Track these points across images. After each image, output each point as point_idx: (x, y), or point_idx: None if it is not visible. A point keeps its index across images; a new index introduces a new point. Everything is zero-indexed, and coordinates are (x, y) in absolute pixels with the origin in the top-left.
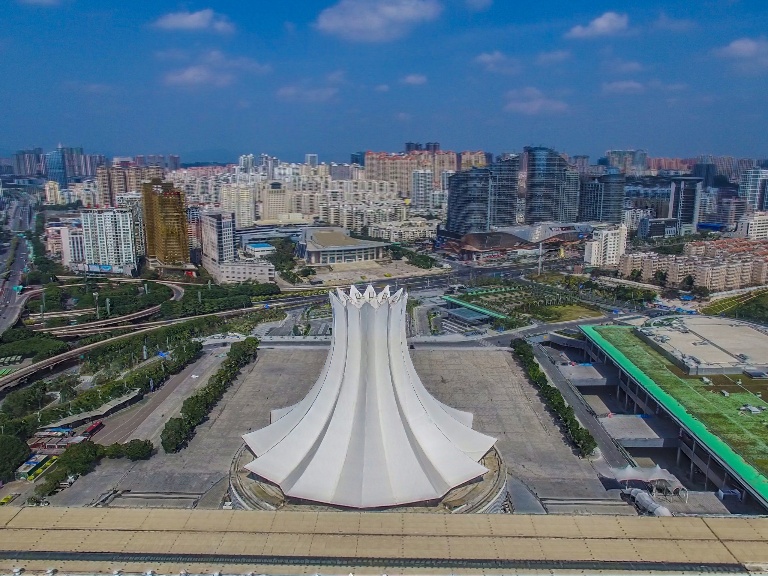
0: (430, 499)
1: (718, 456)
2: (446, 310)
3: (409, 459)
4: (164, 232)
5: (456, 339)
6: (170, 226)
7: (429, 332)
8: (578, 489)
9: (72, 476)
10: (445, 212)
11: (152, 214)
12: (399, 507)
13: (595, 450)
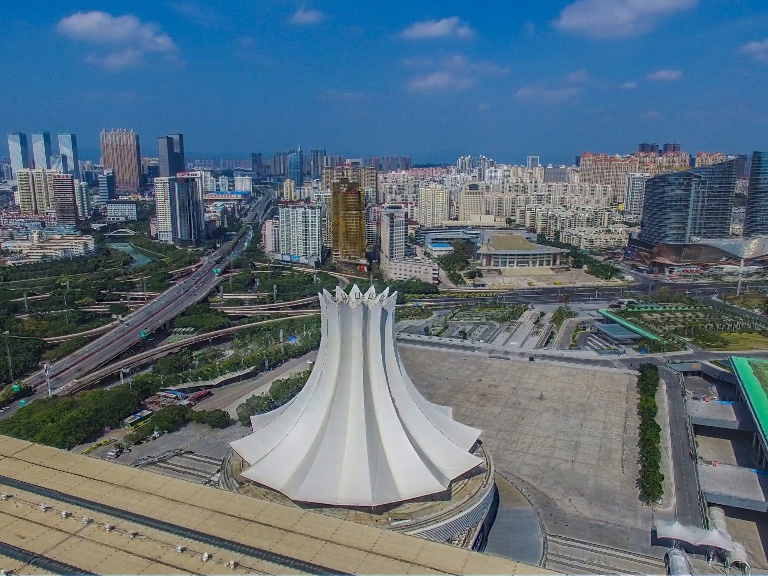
0: (364, 505)
1: None
2: (595, 325)
3: (362, 462)
4: (343, 228)
5: (586, 356)
6: (349, 223)
7: (567, 346)
8: (617, 537)
9: (157, 432)
10: (639, 219)
11: (338, 211)
12: (342, 508)
13: (668, 499)
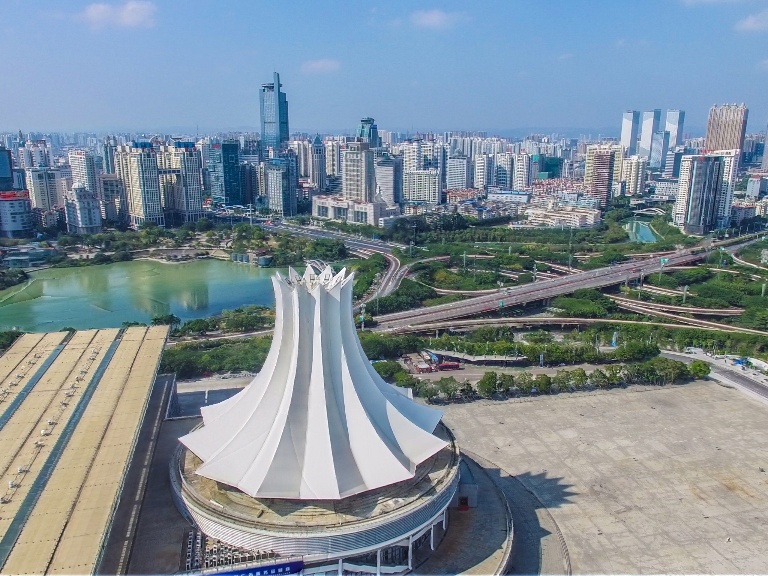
0: None
1: None
2: None
3: None
4: None
5: None
6: None
7: None
8: None
9: None
10: None
11: None
12: None
13: None
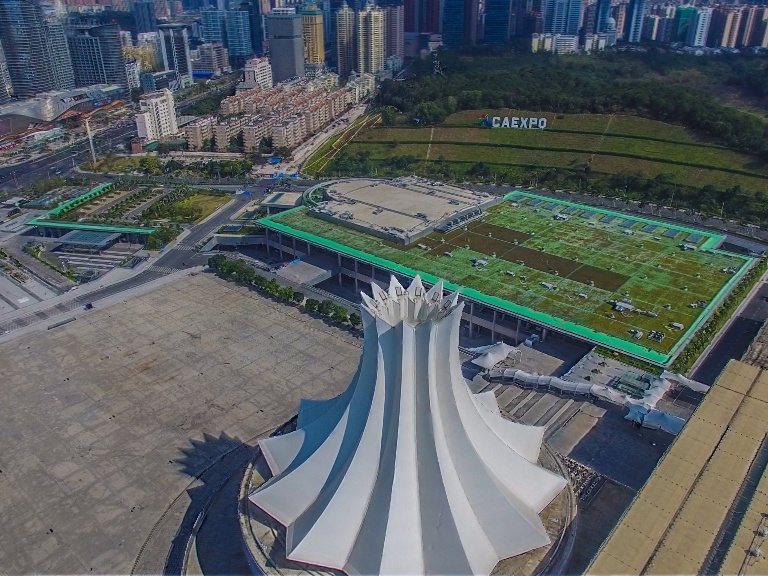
0: None
1: (519, 314)
2: (57, 240)
3: (517, 462)
4: None
5: (125, 276)
6: None
7: (62, 276)
8: None
9: None
10: None
11: None
12: None
13: None
